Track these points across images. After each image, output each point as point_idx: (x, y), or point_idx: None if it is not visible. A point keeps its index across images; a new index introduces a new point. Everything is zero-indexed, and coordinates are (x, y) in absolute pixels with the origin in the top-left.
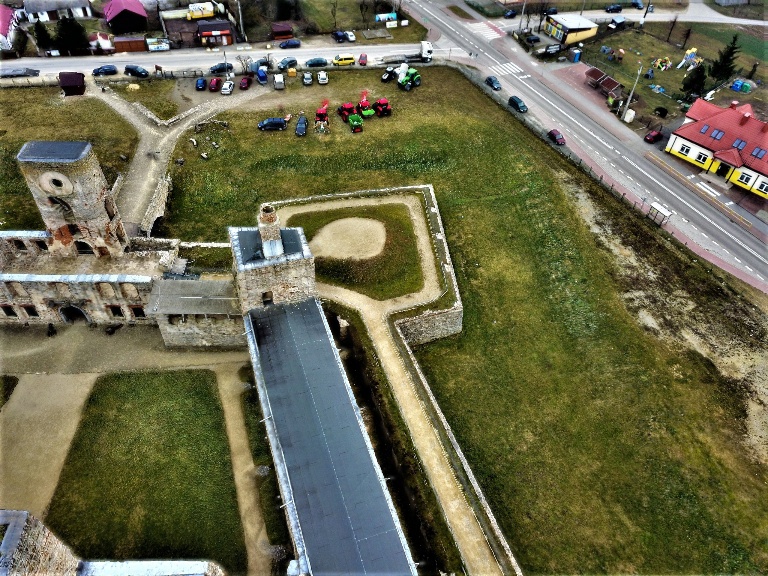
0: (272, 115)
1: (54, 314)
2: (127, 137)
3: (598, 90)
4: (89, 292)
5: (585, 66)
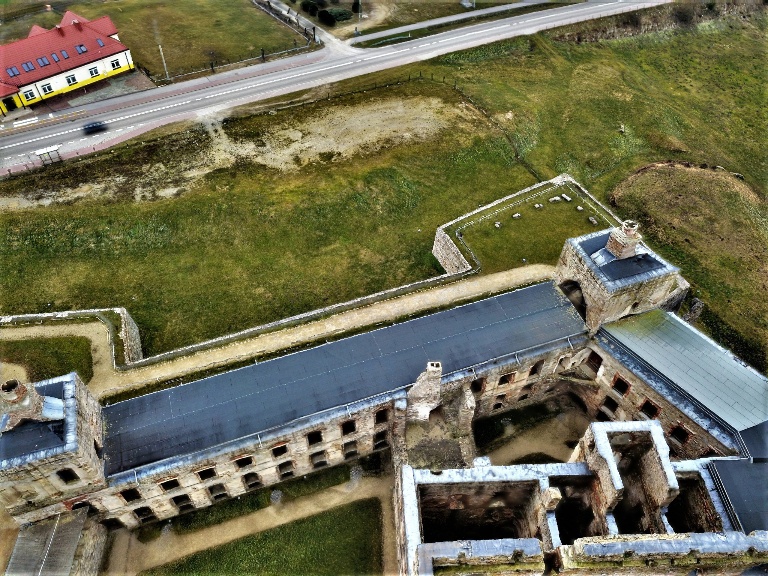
0: None
1: None
2: None
3: None
4: None
5: None
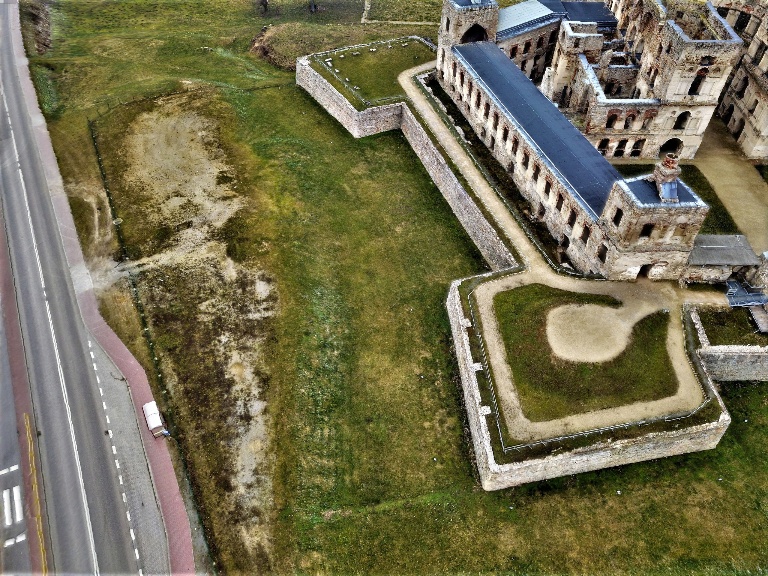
0: None
1: None
2: None
3: None
4: None
5: None
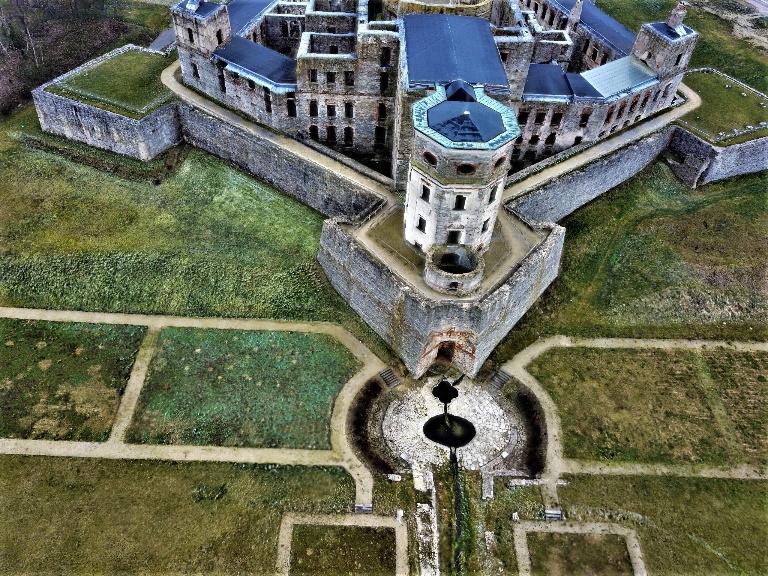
0: None
1: None
2: None
3: None
4: None
5: None
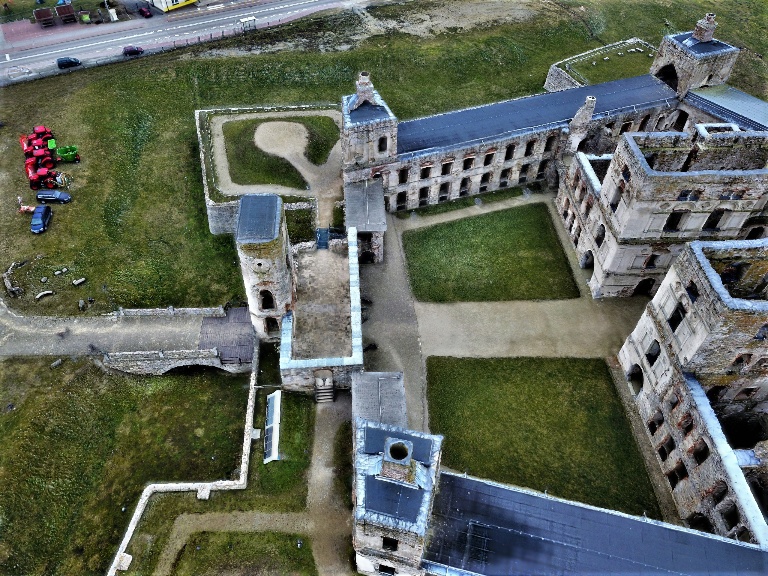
0: (10, 226)
1: None
2: (3, 370)
3: (59, 24)
4: None
5: (8, 24)
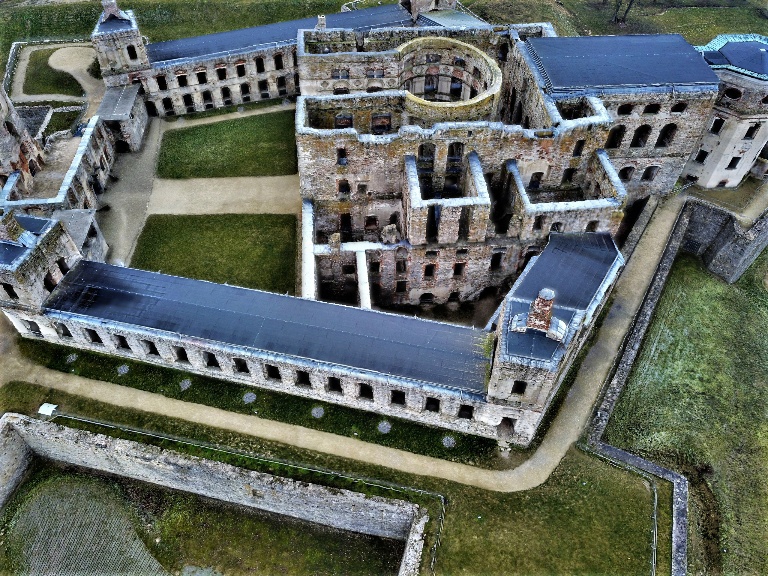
0: None
1: (93, 197)
2: None
3: None
4: (92, 153)
5: None
